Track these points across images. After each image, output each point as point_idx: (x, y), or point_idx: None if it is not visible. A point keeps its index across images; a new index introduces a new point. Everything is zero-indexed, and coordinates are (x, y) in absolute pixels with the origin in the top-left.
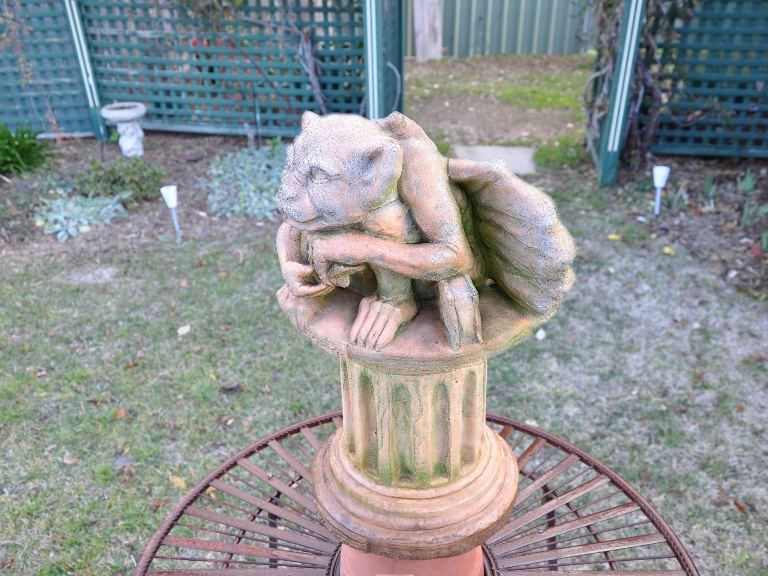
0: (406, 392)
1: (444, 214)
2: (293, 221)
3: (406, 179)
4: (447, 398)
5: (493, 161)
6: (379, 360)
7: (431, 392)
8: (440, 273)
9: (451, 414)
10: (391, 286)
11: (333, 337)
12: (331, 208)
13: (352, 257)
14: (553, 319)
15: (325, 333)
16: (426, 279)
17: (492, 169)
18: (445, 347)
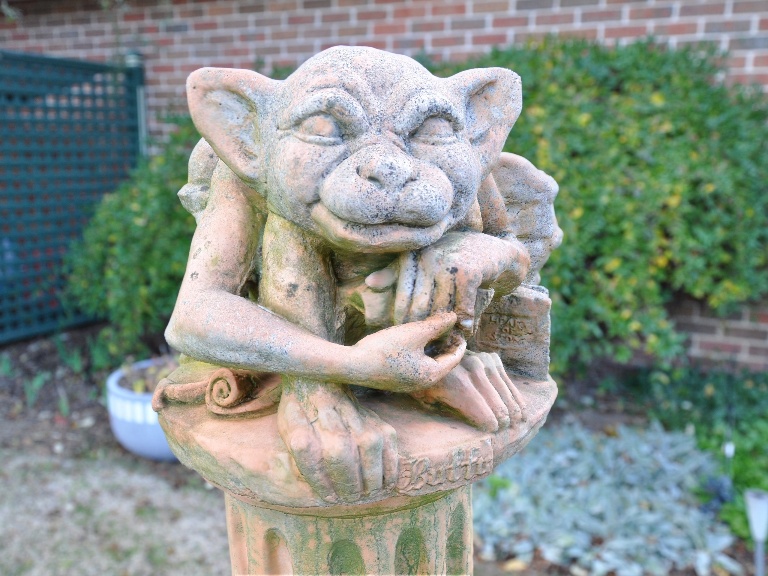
0: (458, 513)
1: None
2: (412, 230)
3: None
4: None
5: None
6: None
7: None
8: None
9: None
10: None
11: (466, 442)
12: (473, 185)
13: None
14: None
15: (447, 446)
16: None
17: None
18: (539, 382)
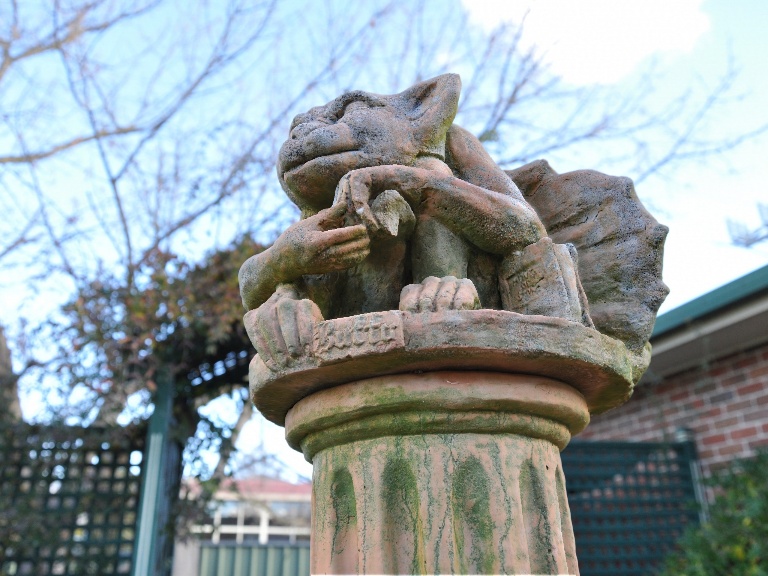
0: (477, 474)
1: (505, 175)
2: None
3: (455, 137)
4: (539, 500)
5: None
6: (461, 327)
7: (517, 474)
8: (521, 223)
9: (551, 536)
10: (448, 261)
11: None
12: (378, 129)
13: (412, 174)
14: (647, 360)
15: None
16: (502, 233)
17: (535, 164)
18: None
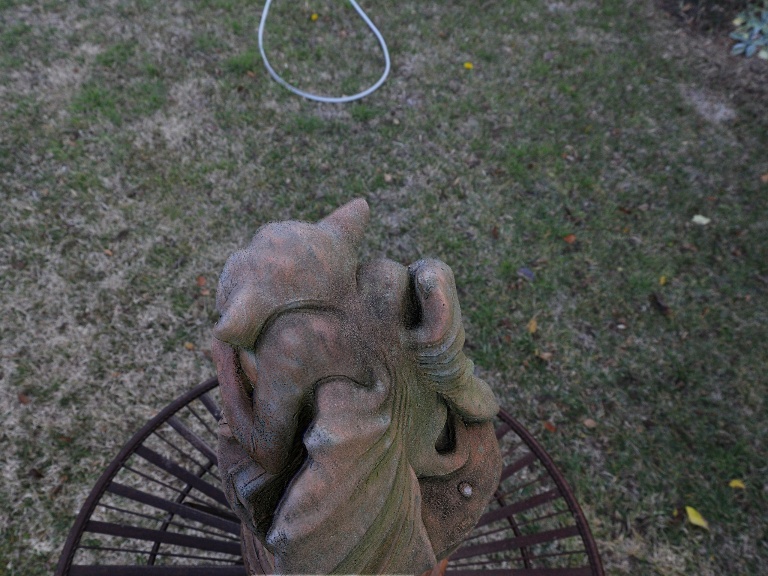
0: None
1: (261, 411)
2: None
3: None
4: None
5: (312, 427)
6: None
7: None
8: None
9: None
10: None
11: None
12: None
13: None
14: None
15: None
16: None
17: None
18: None
